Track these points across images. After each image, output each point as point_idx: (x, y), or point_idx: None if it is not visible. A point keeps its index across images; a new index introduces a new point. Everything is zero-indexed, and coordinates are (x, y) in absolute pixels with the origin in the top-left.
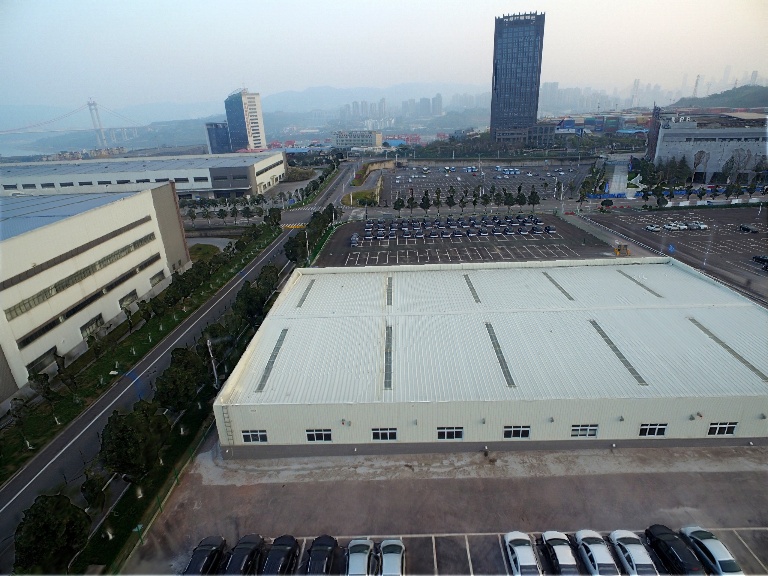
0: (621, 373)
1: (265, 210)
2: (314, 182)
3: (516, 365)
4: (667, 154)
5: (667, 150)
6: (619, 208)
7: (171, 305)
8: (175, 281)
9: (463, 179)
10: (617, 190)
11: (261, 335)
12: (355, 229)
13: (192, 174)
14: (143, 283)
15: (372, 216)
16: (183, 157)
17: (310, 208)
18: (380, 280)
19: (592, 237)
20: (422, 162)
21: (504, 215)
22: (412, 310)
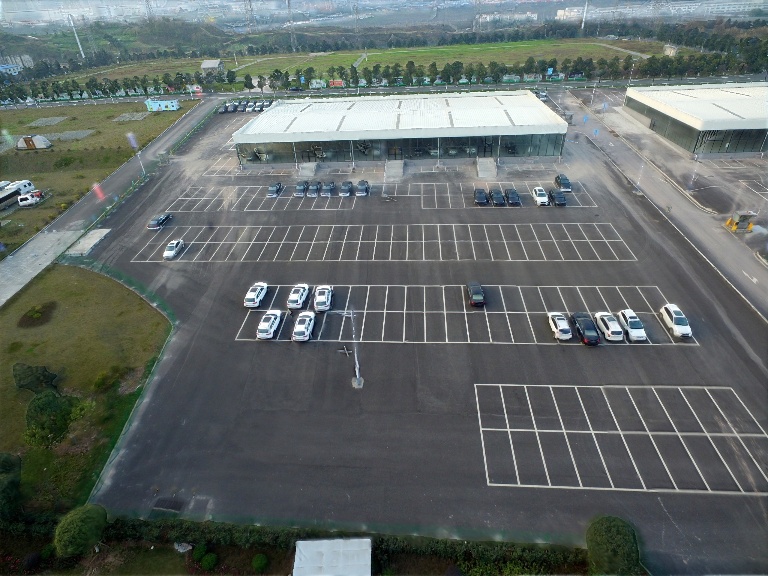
0: (730, 90)
1: None
2: None
3: None
4: None
5: None
6: None
7: None
8: None
9: None
10: None
11: None
12: None
13: None
14: None
15: None
16: None
17: None
18: None
19: None
20: None
21: None
22: None
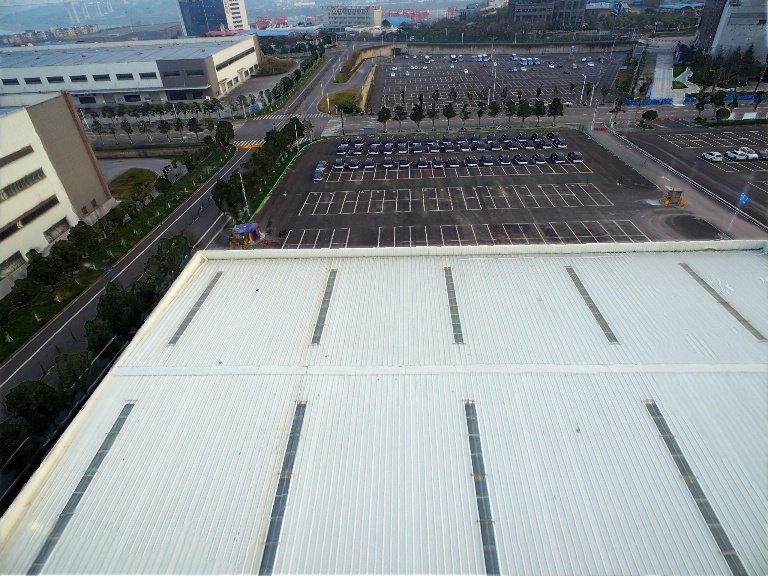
0: (713, 571)
1: (223, 119)
2: (286, 79)
3: (510, 531)
4: (730, 42)
5: (731, 36)
6: (664, 121)
7: (23, 303)
8: (32, 263)
9: (471, 72)
10: (660, 92)
11: (85, 419)
12: (325, 151)
13: (136, 69)
14: (32, 240)
15: (351, 129)
16: (136, 43)
17: (278, 116)
18: (317, 277)
19: (630, 171)
20: (424, 48)
21: (516, 131)
22: (348, 360)
